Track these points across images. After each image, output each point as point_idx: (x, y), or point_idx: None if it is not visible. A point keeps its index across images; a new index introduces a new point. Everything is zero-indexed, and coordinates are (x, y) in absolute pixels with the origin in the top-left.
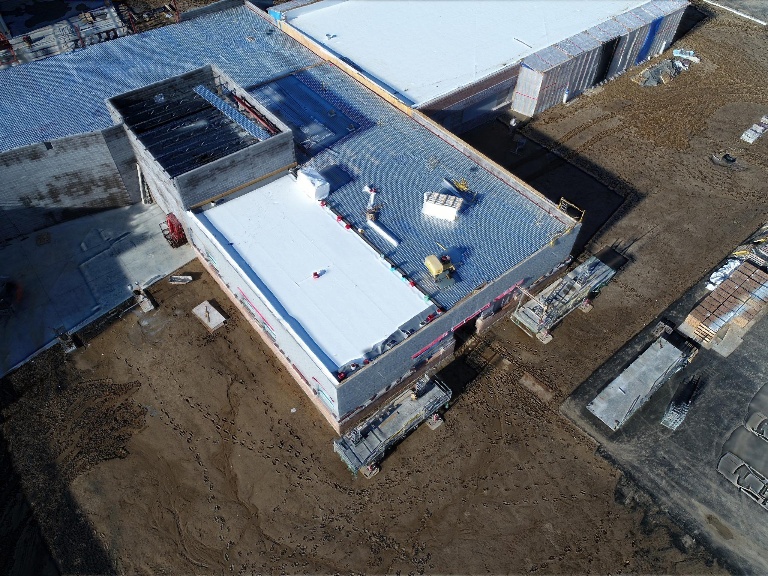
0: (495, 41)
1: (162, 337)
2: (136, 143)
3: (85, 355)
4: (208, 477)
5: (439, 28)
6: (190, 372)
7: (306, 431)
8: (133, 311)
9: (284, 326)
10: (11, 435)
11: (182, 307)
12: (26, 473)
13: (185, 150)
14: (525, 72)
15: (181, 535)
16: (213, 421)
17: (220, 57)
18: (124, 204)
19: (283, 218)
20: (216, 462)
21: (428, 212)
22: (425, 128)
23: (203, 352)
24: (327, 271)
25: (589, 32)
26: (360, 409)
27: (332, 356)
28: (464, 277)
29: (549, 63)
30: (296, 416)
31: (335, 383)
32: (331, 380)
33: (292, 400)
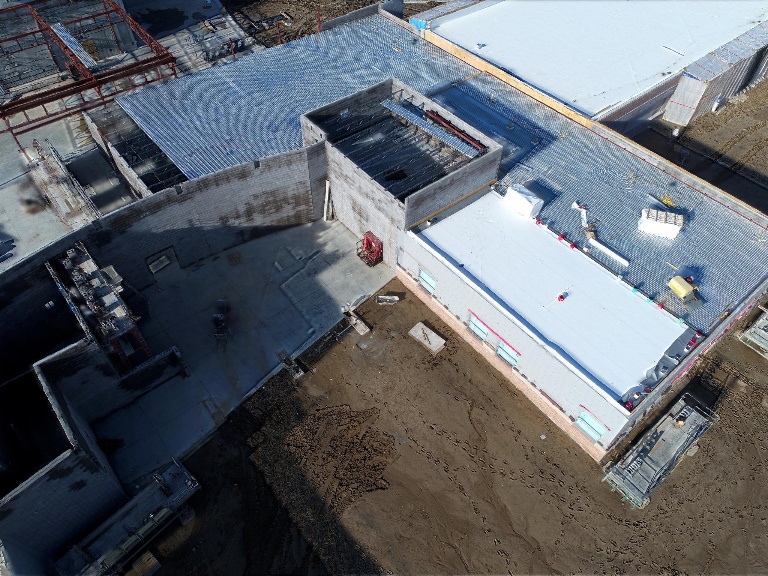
0: (645, 49)
1: (386, 361)
2: (341, 161)
3: (314, 380)
4: (478, 509)
5: (585, 36)
6: (426, 397)
7: (563, 459)
8: (348, 333)
9: (550, 352)
10: (264, 466)
11: (396, 329)
12: (292, 506)
13: (396, 168)
14: (686, 81)
15: (469, 571)
16: (465, 449)
17: (374, 68)
18: (306, 221)
19: (504, 237)
20: (481, 493)
21: (646, 230)
22: (608, 141)
23: (433, 376)
24: (569, 293)
25: (741, 39)
26: (623, 436)
27: (609, 384)
28: (708, 298)
29: (712, 72)
30: (548, 443)
31: (626, 413)
32: (620, 410)
33: (539, 426)
